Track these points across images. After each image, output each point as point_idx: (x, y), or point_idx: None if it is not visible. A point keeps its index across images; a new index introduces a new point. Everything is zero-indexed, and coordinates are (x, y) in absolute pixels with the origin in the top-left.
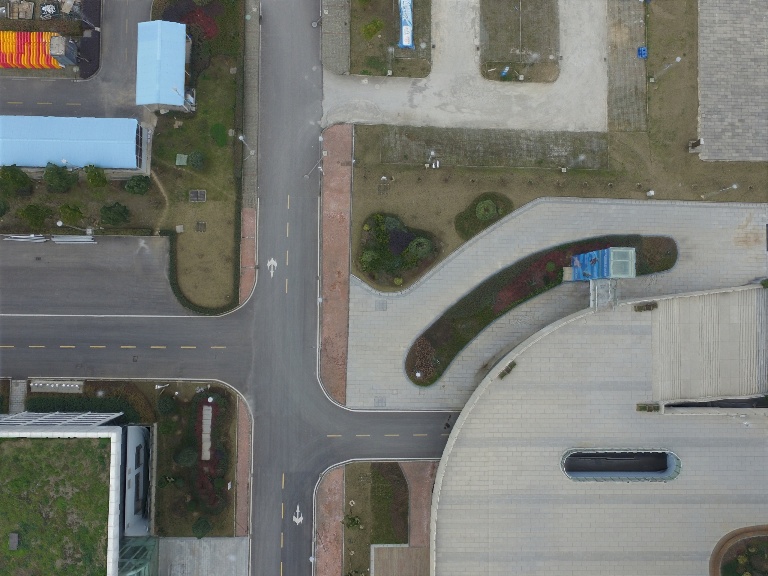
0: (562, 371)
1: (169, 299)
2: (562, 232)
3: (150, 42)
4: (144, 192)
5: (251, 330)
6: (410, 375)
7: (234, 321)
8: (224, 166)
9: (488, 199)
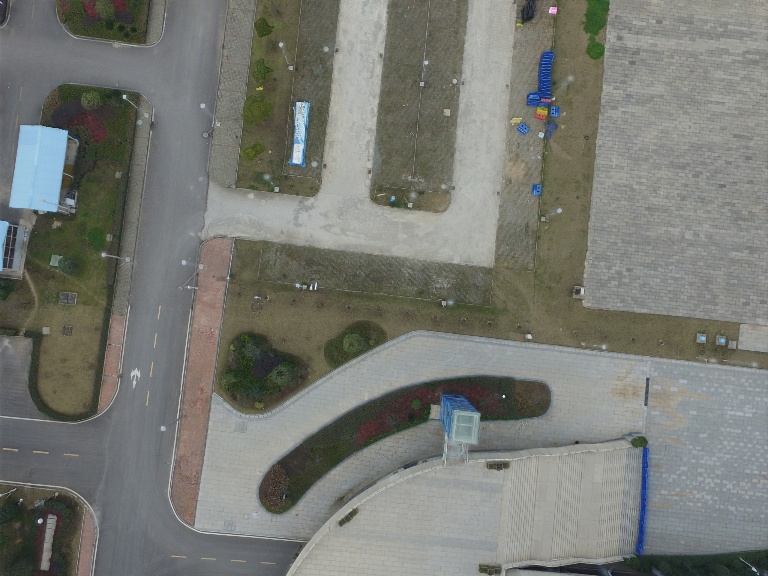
0: (406, 523)
1: (27, 401)
2: (434, 368)
3: (29, 146)
4: (3, 299)
5: (107, 440)
6: (262, 502)
7: (90, 429)
8: (98, 271)
9: (361, 328)
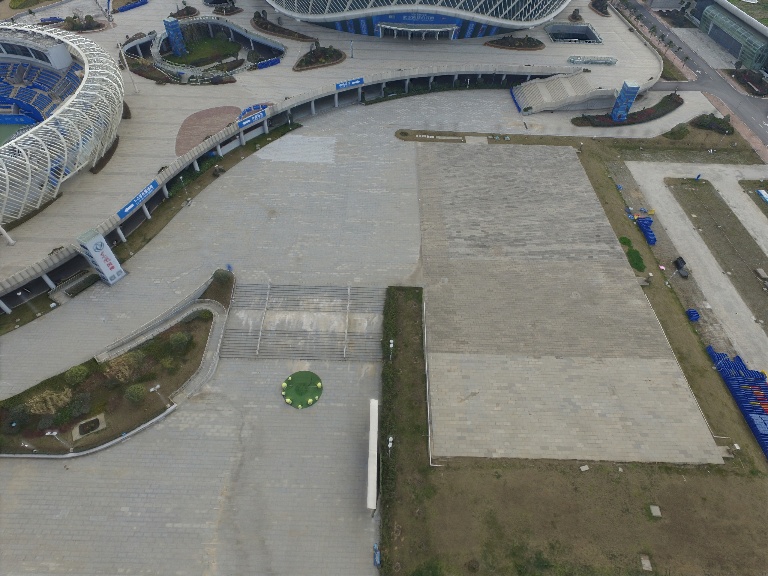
0: None
1: None
2: None
3: None
4: None
5: (759, 109)
6: None
7: None
8: None
9: (678, 137)
